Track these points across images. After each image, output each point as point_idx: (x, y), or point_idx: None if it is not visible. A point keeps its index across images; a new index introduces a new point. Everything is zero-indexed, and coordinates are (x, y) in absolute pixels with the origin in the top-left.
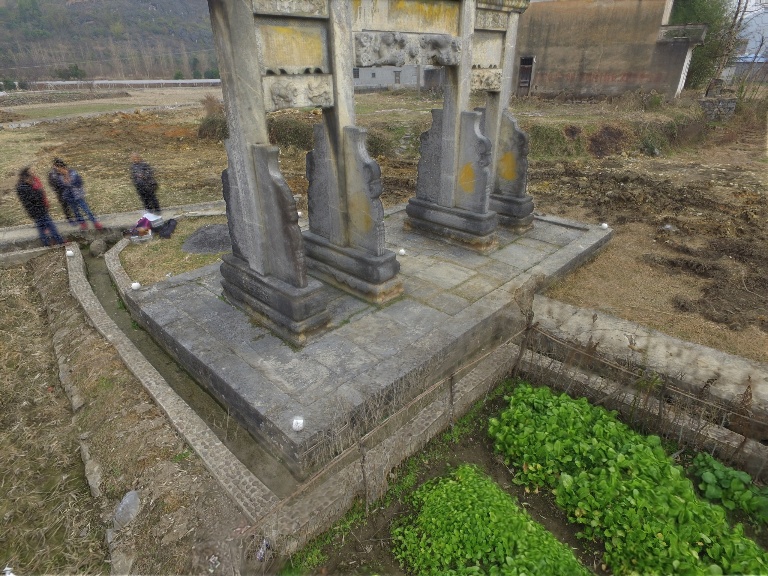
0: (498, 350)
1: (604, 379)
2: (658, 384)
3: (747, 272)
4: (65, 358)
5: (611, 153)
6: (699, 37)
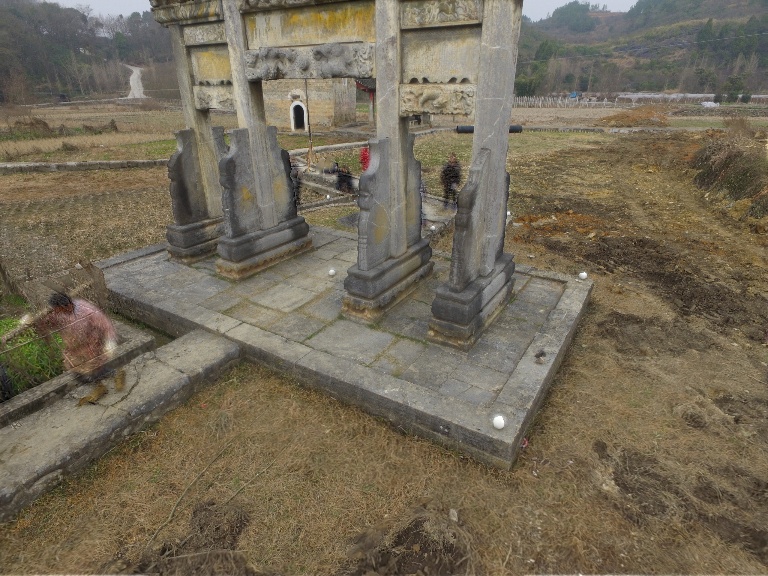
0: (142, 332)
1: None
2: None
3: None
4: None
5: None
6: None
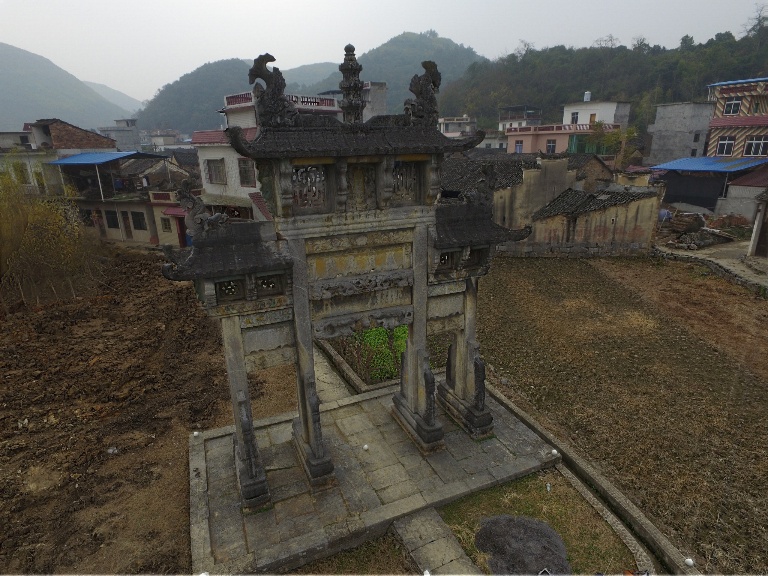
0: (371, 389)
1: None
2: None
3: None
4: None
5: None
6: None
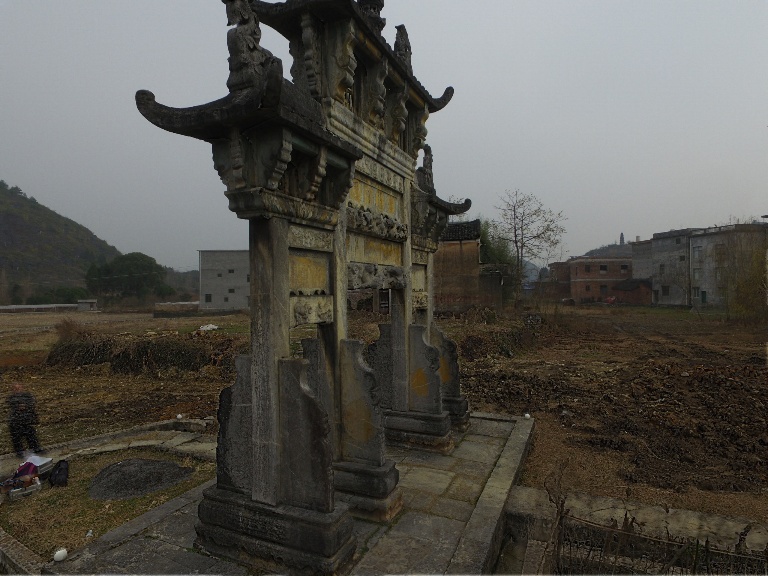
0: (528, 550)
1: (648, 556)
2: (701, 548)
3: (646, 443)
4: None
5: (479, 357)
6: (507, 272)
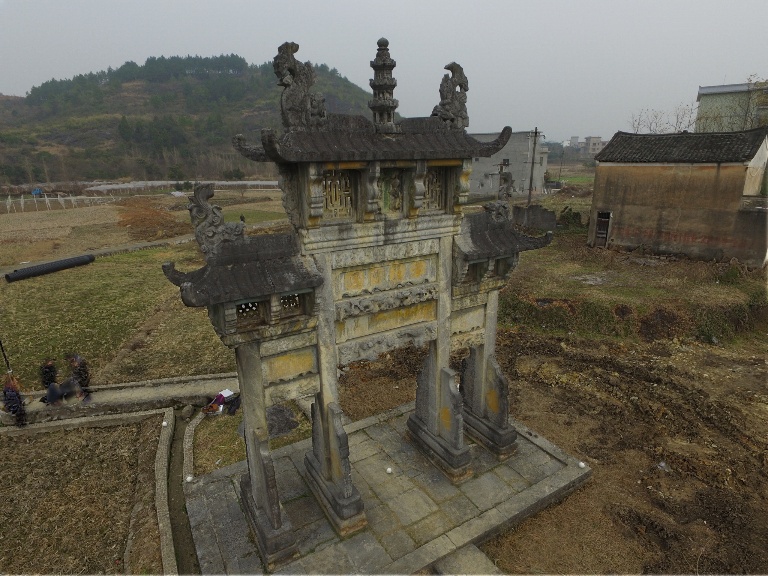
0: None
1: None
2: None
3: (709, 549)
4: (133, 535)
5: (662, 337)
6: None
